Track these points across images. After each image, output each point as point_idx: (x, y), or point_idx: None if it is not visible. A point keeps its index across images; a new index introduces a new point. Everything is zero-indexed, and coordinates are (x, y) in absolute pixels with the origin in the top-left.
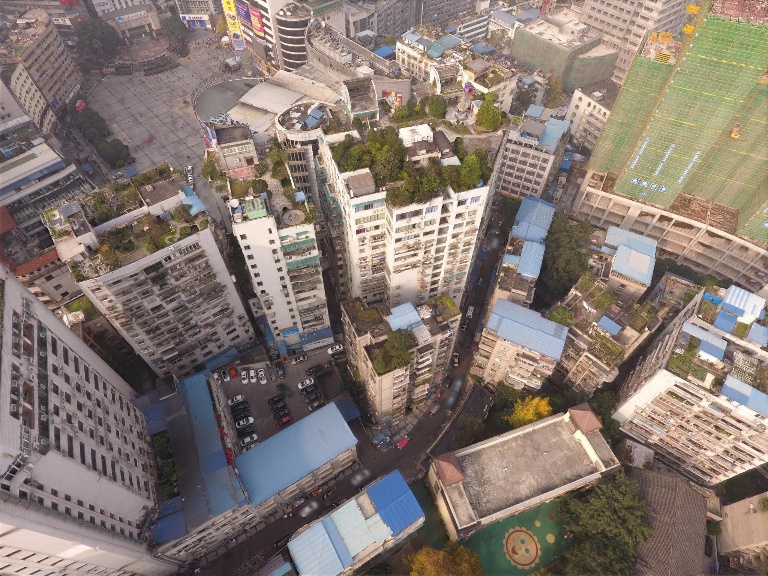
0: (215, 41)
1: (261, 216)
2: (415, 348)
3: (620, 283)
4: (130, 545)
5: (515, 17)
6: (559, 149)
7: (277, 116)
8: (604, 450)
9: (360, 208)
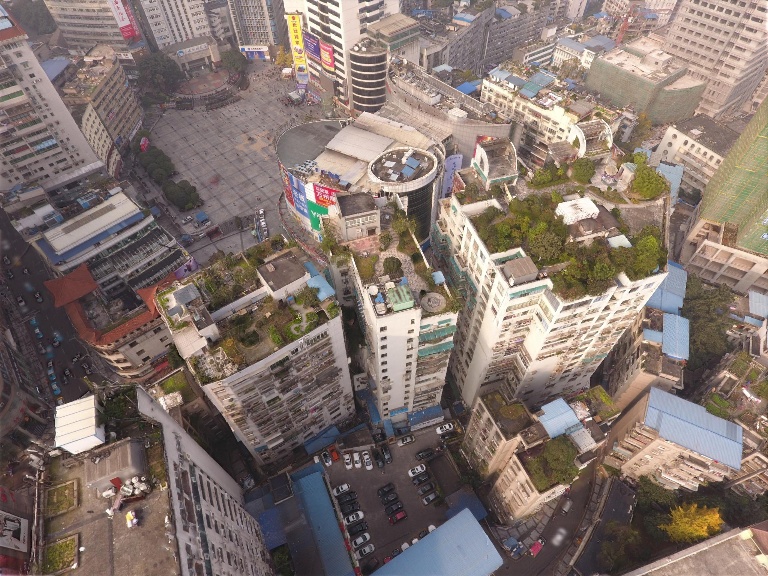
0: (275, 73)
1: (407, 307)
2: None
3: None
4: None
5: (583, 44)
6: None
7: (369, 165)
8: None
9: (516, 296)
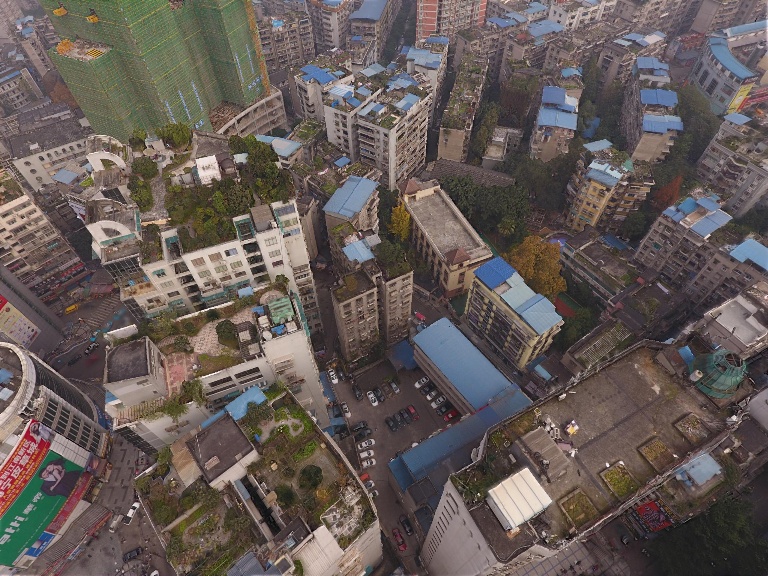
0: None
1: None
2: None
3: (294, 160)
4: None
5: None
6: None
7: None
8: (427, 185)
9: None
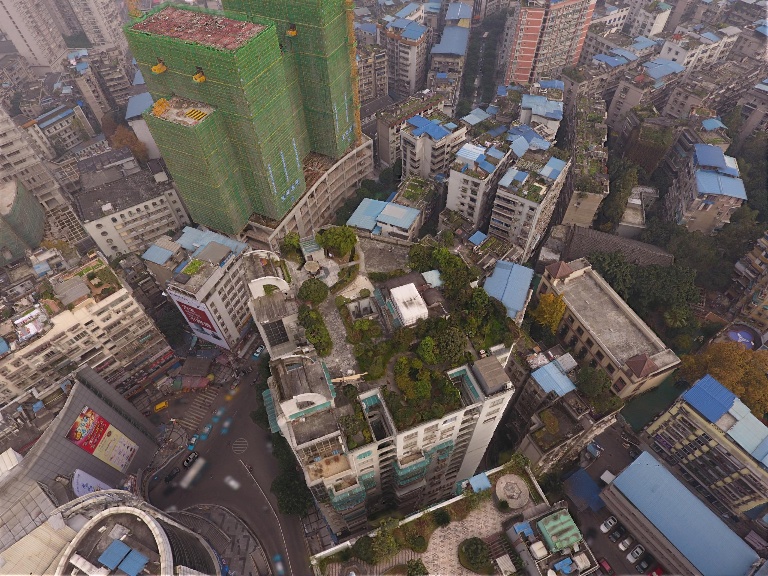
0: None
1: None
2: None
3: None
4: None
5: None
6: None
7: None
8: (576, 264)
9: None
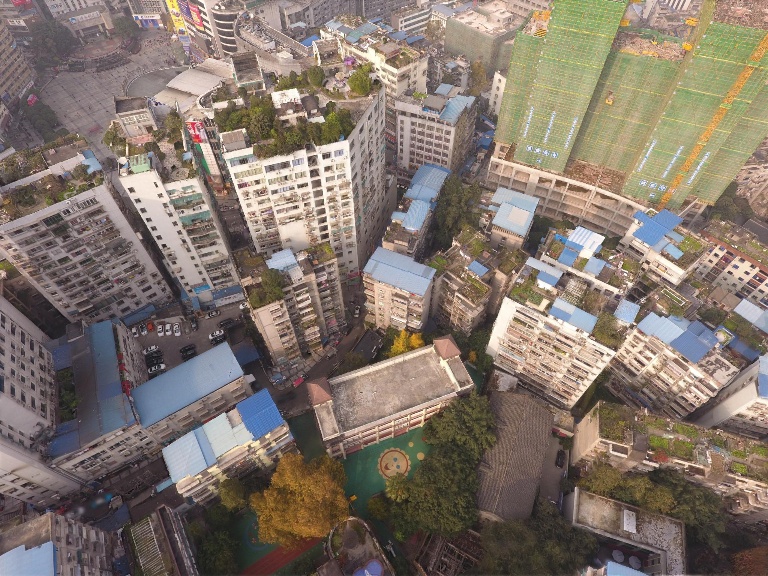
0: (166, 39)
1: (145, 170)
2: (290, 287)
3: (501, 236)
4: (18, 449)
5: (454, 10)
6: (465, 123)
7: (199, 98)
8: (462, 373)
9: (236, 163)
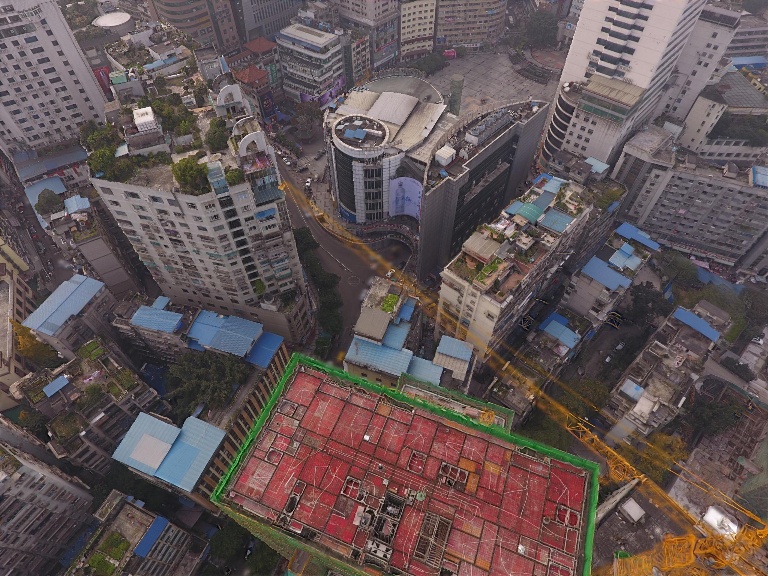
0: None
1: None
2: None
3: None
4: None
5: None
6: None
7: (357, 114)
8: None
9: None
